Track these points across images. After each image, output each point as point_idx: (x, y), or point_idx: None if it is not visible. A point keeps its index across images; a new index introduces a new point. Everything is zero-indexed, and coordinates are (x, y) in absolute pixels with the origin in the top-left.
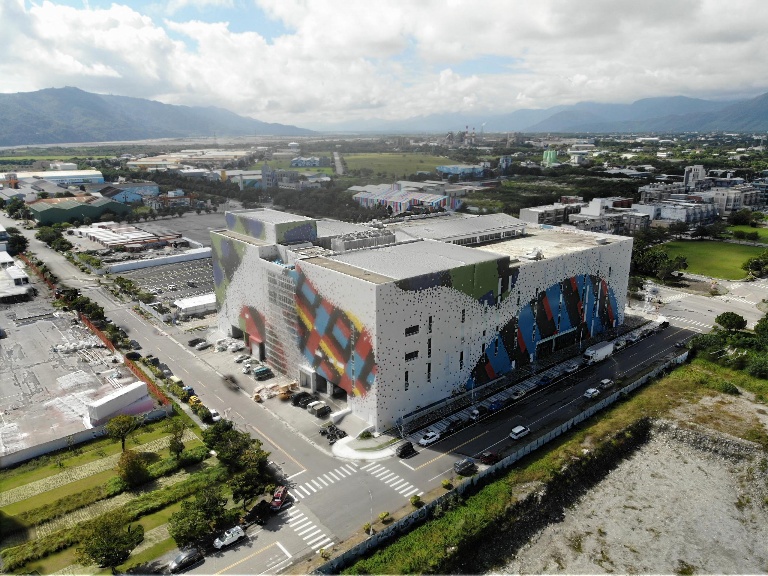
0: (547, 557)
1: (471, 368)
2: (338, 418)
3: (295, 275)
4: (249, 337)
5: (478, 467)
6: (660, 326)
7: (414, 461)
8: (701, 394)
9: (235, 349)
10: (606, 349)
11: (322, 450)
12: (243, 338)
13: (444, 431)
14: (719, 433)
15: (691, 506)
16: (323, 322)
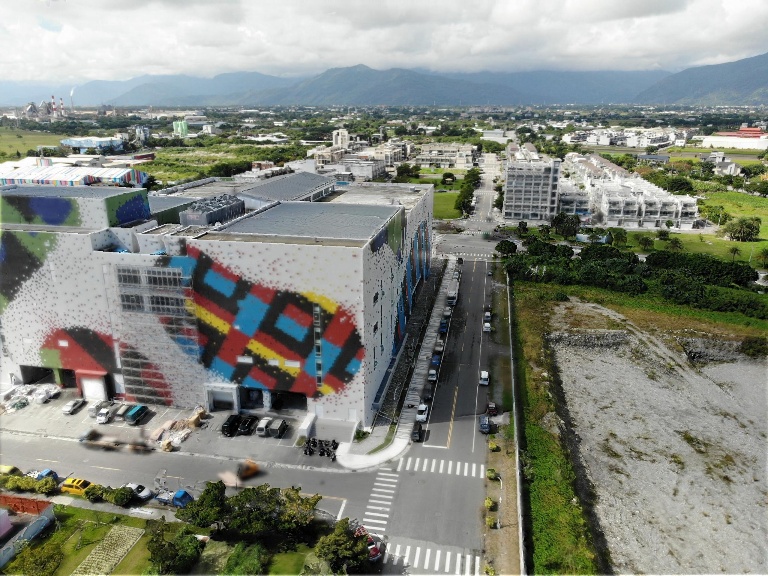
0: (609, 473)
1: (394, 331)
2: (309, 429)
3: (187, 262)
4: (77, 373)
5: (492, 421)
6: (459, 262)
7: (436, 440)
8: (550, 306)
9: (45, 398)
10: (457, 288)
11: (332, 471)
12: (43, 380)
13: (422, 401)
14: (597, 330)
15: (632, 390)
16: (254, 316)
